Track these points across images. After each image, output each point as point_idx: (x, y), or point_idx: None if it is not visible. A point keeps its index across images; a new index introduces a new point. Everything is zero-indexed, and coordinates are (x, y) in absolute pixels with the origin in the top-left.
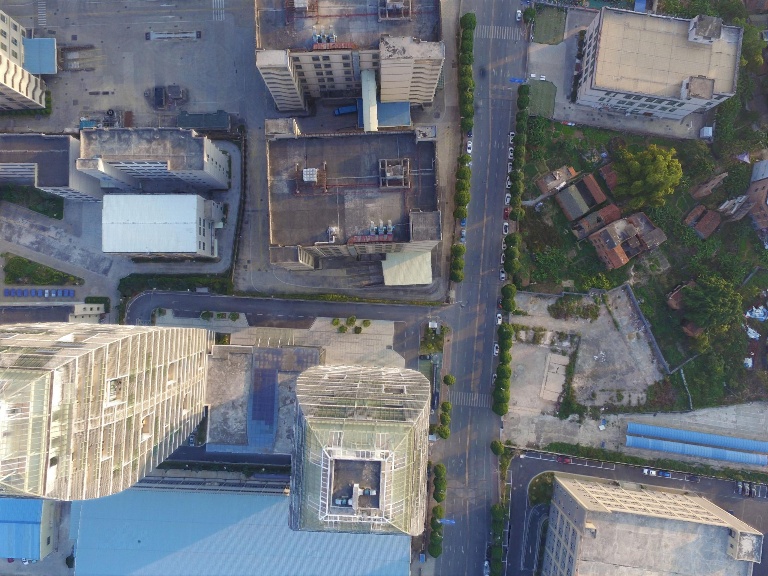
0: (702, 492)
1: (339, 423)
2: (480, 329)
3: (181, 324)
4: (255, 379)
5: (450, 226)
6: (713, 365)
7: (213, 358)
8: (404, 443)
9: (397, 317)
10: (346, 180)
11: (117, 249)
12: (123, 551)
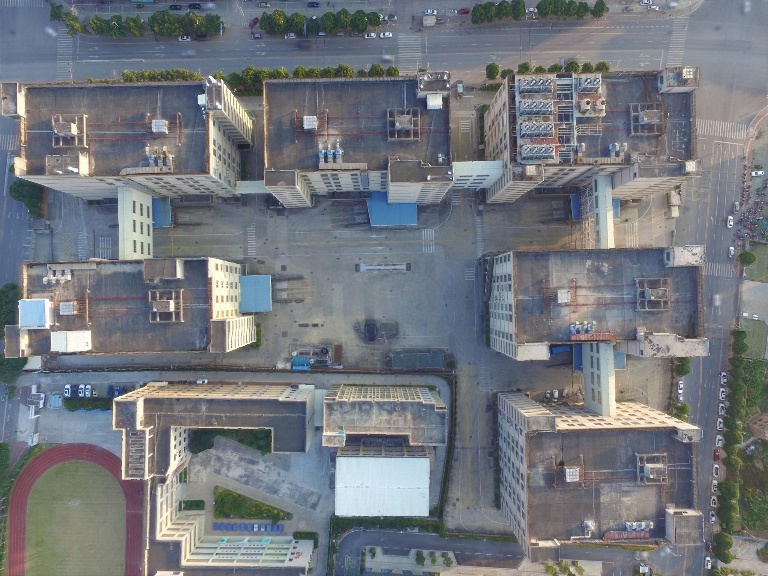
0: None
1: None
2: (688, 571)
3: (390, 562)
4: None
5: None
6: None
7: None
8: None
9: (605, 558)
10: (602, 473)
11: (350, 513)
12: None
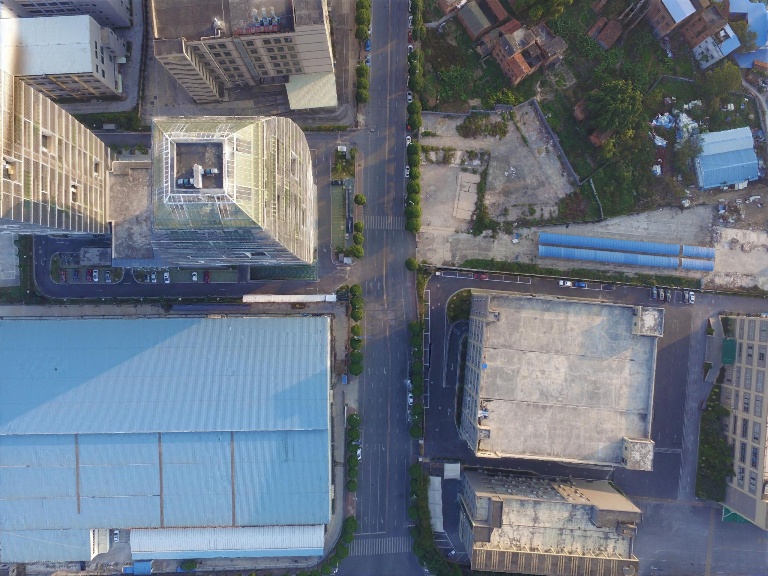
0: (618, 301)
1: (186, 121)
2: (390, 152)
3: None
4: None
5: (355, 53)
6: (621, 171)
7: (114, 174)
8: (248, 131)
9: None
10: None
11: (12, 73)
12: (40, 379)
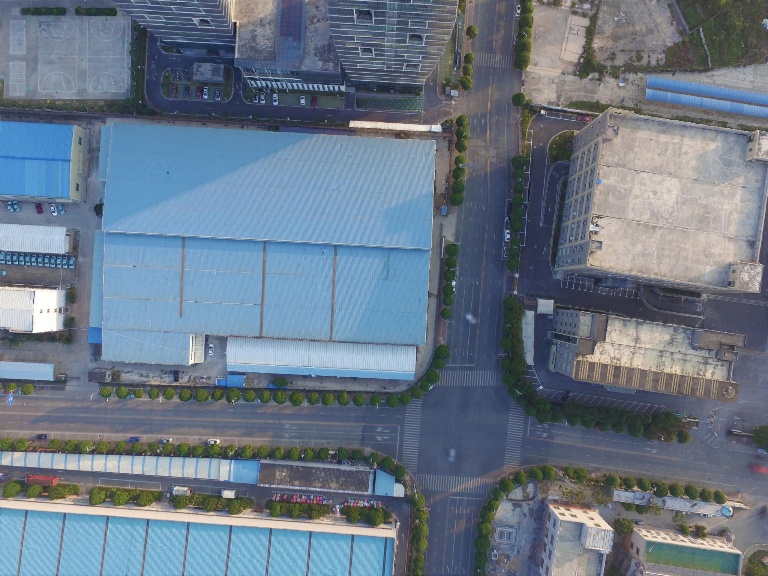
0: None
1: None
2: None
3: None
4: None
5: None
6: (732, 20)
7: None
8: None
9: None
10: None
11: None
12: (152, 181)
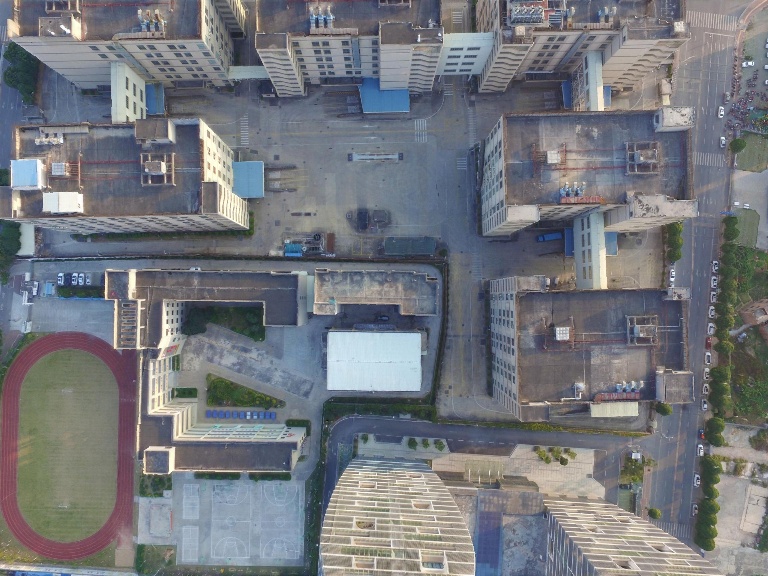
0: None
1: None
2: (680, 459)
3: (383, 449)
4: (480, 522)
5: None
6: None
7: None
8: None
9: (597, 445)
10: (593, 336)
11: (342, 387)
12: None
